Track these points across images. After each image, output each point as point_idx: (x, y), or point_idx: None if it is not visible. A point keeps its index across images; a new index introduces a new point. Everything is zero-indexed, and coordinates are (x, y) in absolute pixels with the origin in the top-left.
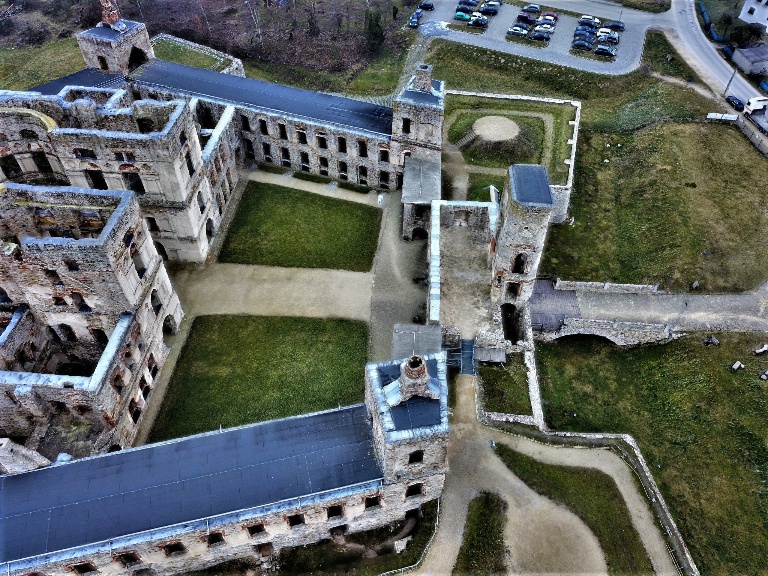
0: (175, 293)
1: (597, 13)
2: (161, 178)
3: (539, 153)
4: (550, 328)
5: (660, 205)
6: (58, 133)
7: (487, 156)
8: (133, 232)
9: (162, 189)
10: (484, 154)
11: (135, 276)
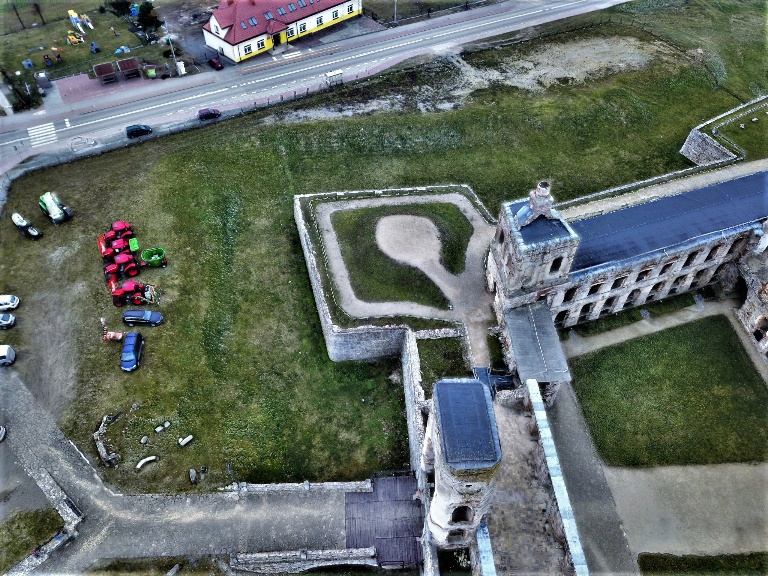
0: None
1: None
2: None
3: None
4: (386, 479)
5: None
6: None
7: None
8: None
9: None
10: None
11: None
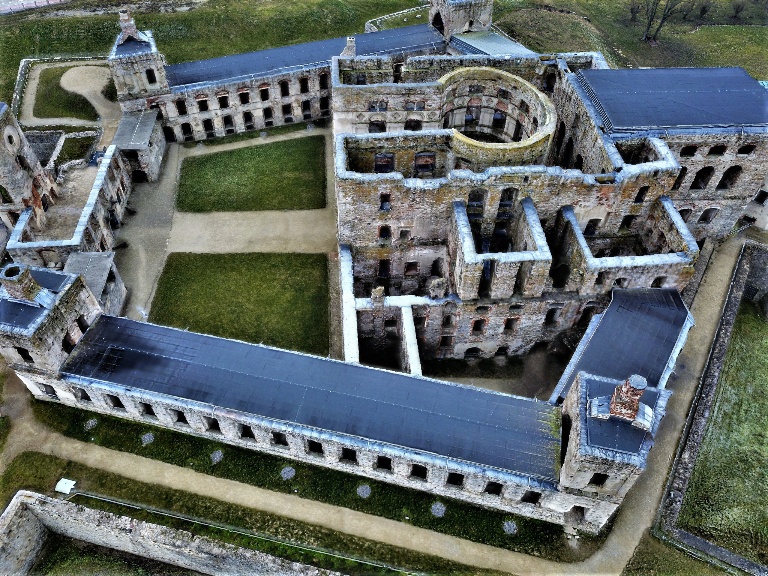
0: None
1: None
2: None
3: None
4: None
5: None
6: None
7: None
8: None
9: None
10: None
11: None
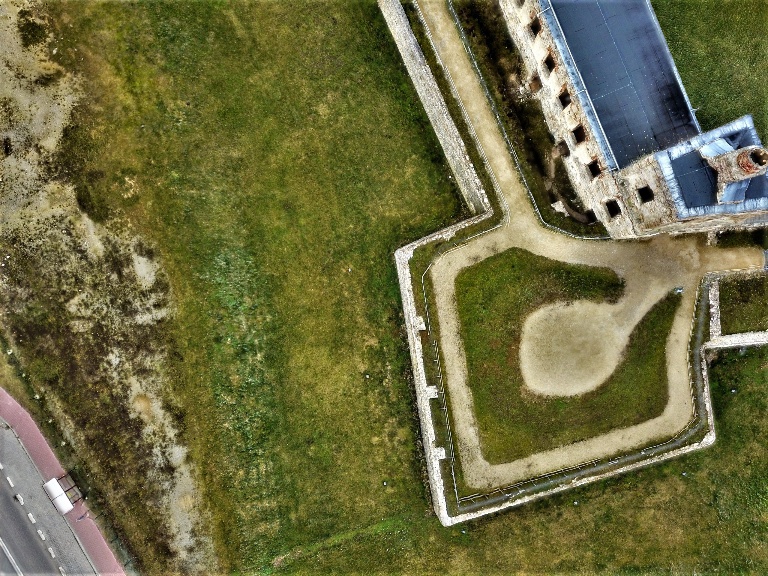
0: None
1: None
2: None
3: None
4: None
5: None
6: None
7: None
8: None
9: None
10: None
11: None
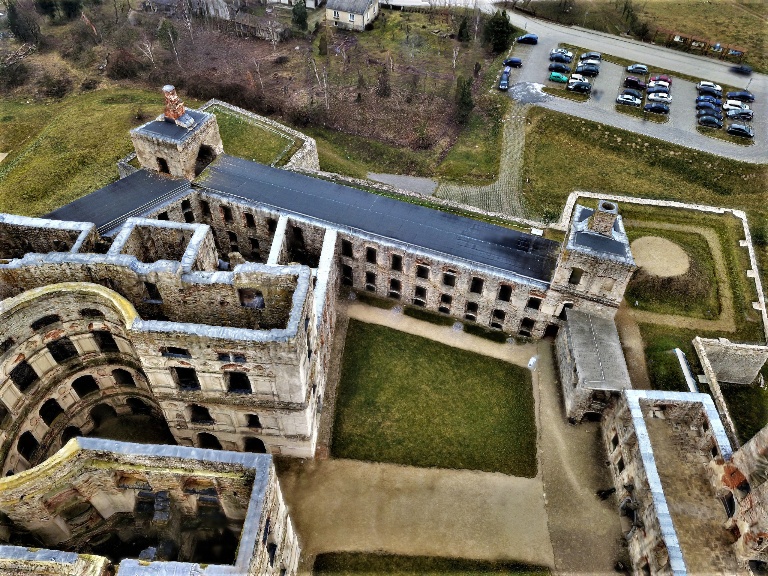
0: (295, 536)
1: (715, 77)
2: (278, 379)
3: (716, 290)
4: None
5: None
6: (141, 330)
7: (655, 297)
8: (269, 514)
9: (276, 390)
10: (651, 294)
11: (268, 570)
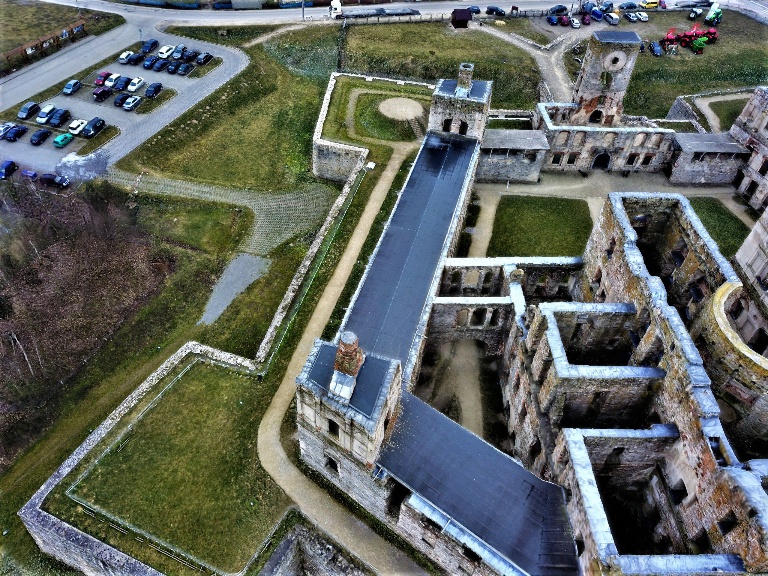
0: None
1: (106, 51)
2: None
3: None
4: None
5: (454, 69)
6: None
7: None
8: None
9: None
10: None
11: None
